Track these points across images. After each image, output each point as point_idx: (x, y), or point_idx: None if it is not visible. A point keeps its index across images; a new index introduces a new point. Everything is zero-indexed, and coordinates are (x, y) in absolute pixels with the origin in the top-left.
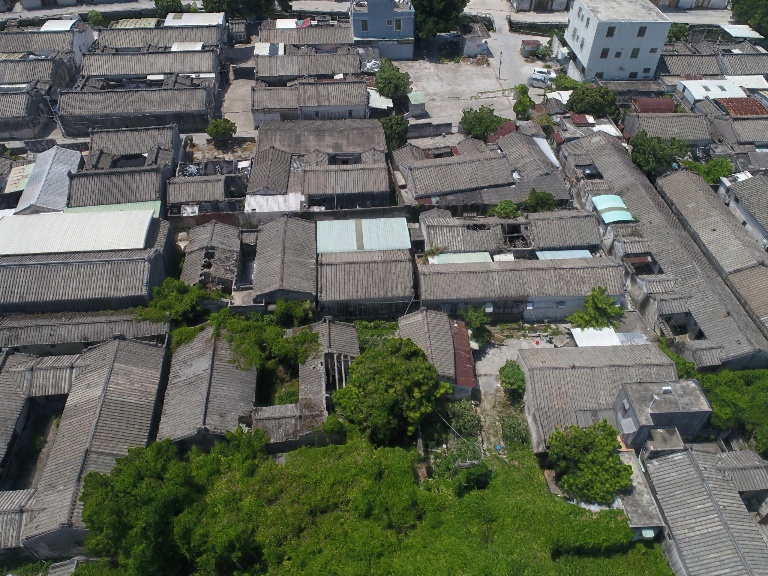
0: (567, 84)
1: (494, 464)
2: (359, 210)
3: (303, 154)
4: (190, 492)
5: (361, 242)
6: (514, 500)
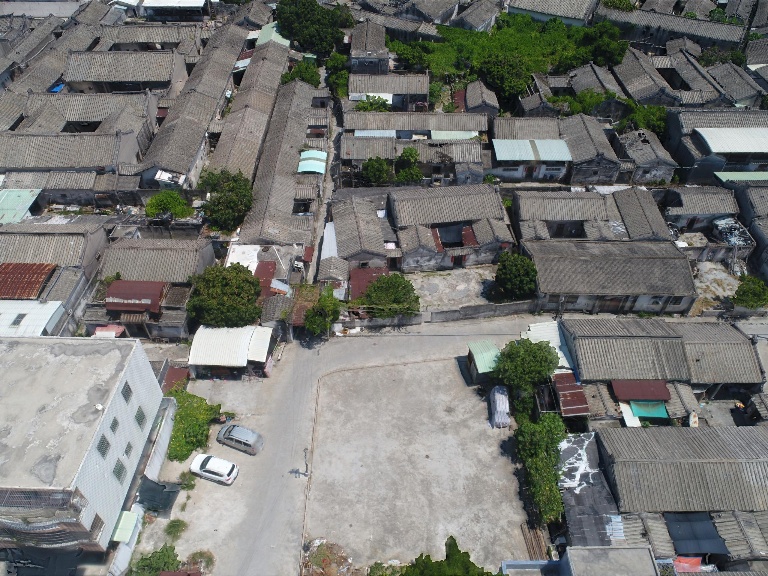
0: (203, 404)
1: (451, 71)
2: (539, 187)
3: (618, 239)
4: (583, 41)
5: (532, 143)
6: (447, 57)
